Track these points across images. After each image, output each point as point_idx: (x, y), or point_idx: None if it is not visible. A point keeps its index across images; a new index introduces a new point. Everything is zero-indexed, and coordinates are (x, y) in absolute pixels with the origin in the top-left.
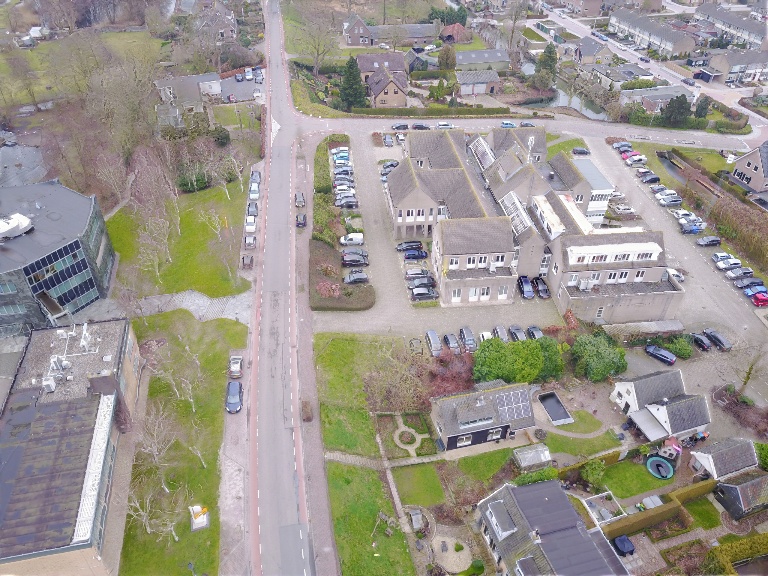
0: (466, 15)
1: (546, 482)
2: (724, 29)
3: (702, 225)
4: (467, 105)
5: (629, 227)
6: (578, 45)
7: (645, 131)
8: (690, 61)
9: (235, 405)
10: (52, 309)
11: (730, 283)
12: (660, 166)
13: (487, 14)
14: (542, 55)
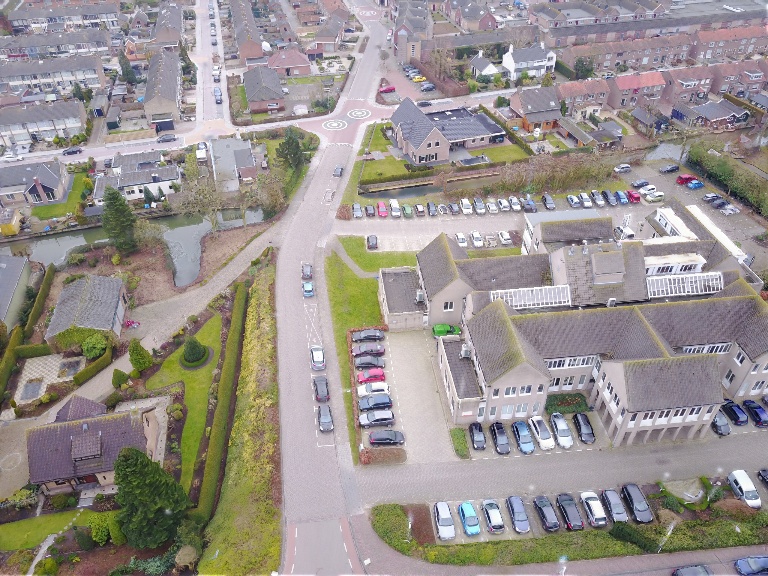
0: None
1: None
2: (30, 83)
3: (529, 197)
4: (180, 335)
5: (664, 215)
6: None
7: (311, 190)
8: (113, 123)
9: None
10: None
11: (609, 207)
12: (387, 200)
13: None
14: (109, 210)
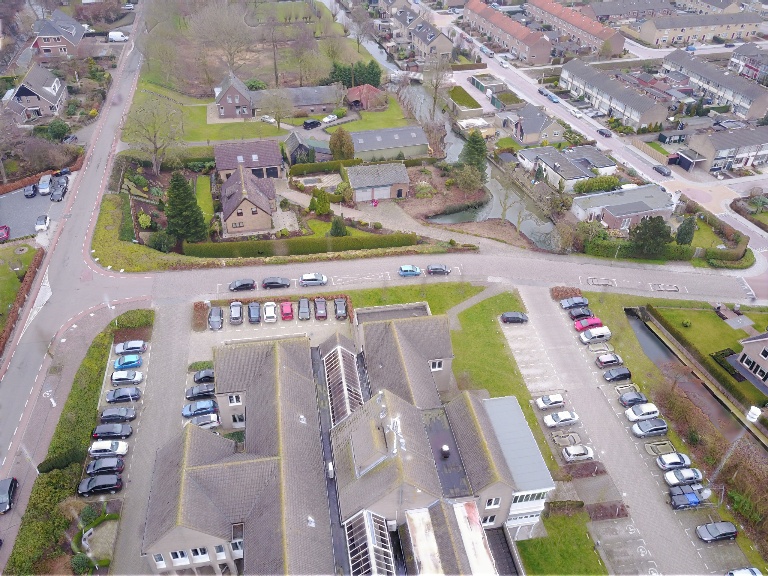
0: (379, 72)
1: None
2: (701, 85)
3: (704, 494)
4: (360, 223)
5: None
6: (519, 118)
7: (607, 269)
8: (663, 137)
9: None
10: None
11: None
12: (631, 337)
13: (410, 65)
14: (466, 145)
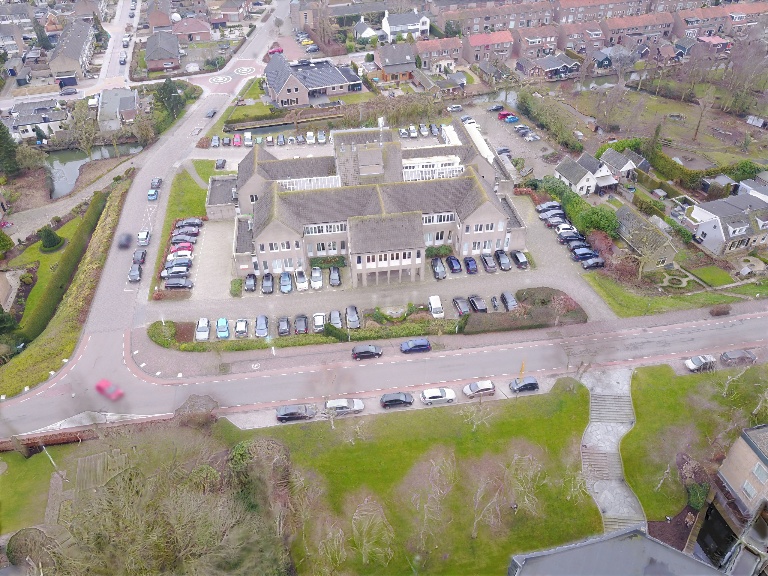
0: None
1: (701, 207)
2: None
3: None
4: None
5: (444, 131)
6: None
7: (182, 128)
8: (22, 80)
9: (750, 354)
10: (747, 572)
11: (432, 137)
12: None
13: None
14: None
